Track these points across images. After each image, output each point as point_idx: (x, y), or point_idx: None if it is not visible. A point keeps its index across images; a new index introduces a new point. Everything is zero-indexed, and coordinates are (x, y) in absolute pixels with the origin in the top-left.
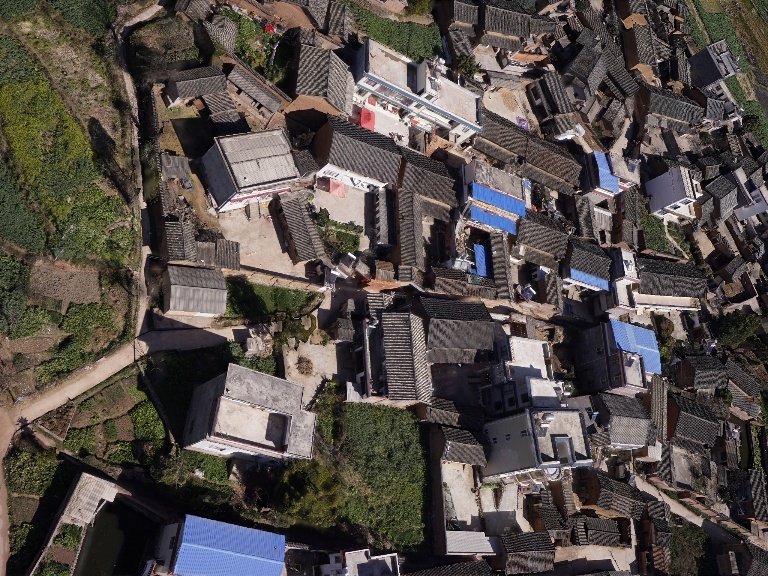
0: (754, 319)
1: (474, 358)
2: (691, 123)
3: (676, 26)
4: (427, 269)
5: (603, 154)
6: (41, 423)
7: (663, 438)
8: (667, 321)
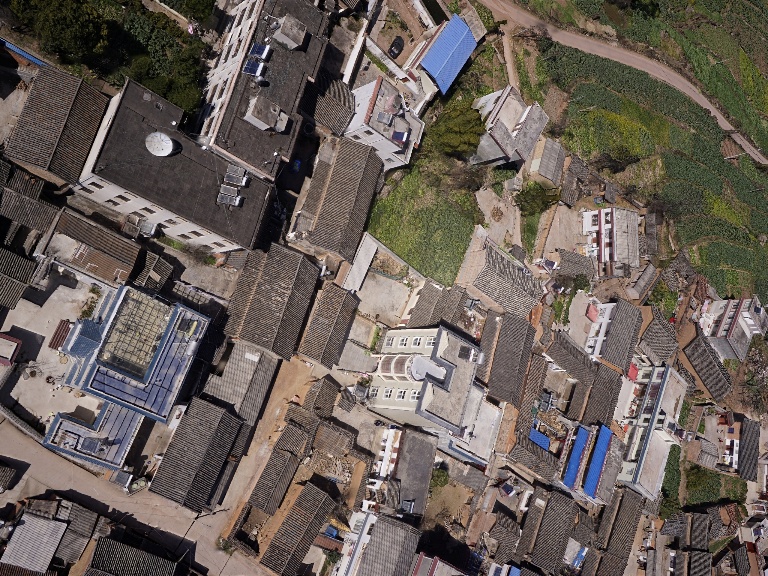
0: None
1: (477, 377)
2: None
3: None
4: None
5: None
6: None
7: None
8: None
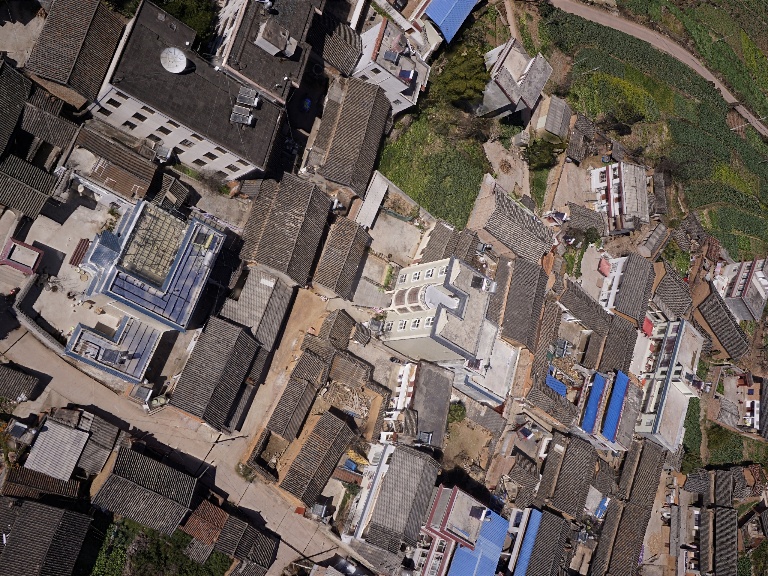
0: None
1: None
2: None
3: None
4: None
5: None
6: (504, 3)
7: None
8: None
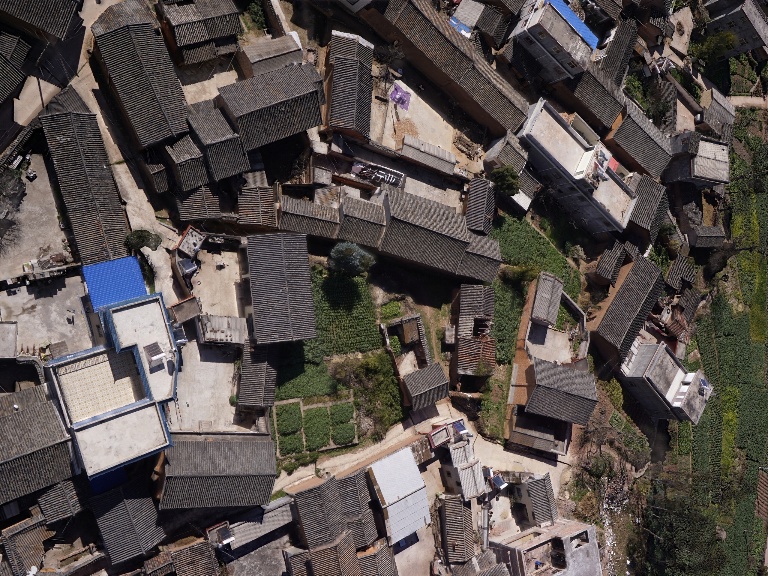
0: None
1: None
2: None
3: None
4: None
5: None
6: (762, 94)
7: None
8: None
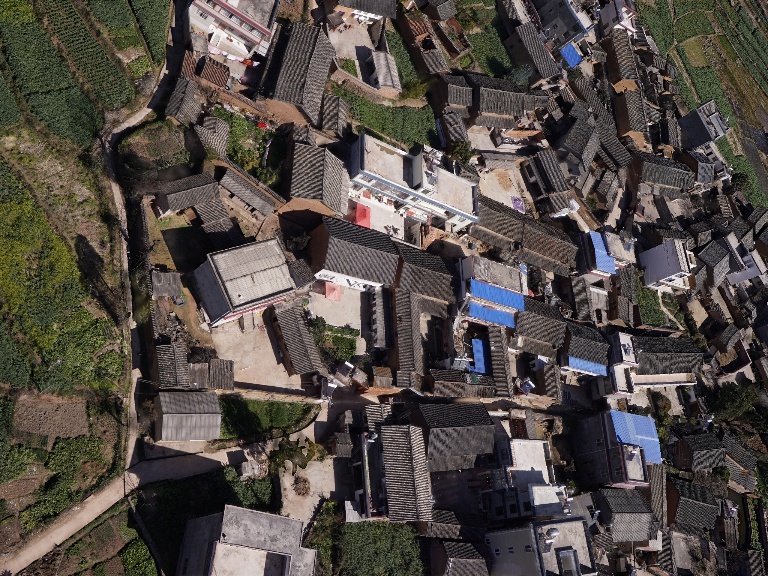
0: (750, 394)
1: (474, 462)
2: (683, 188)
3: (665, 86)
4: (425, 368)
5: (599, 234)
6: (26, 575)
7: (664, 527)
8: (664, 399)
